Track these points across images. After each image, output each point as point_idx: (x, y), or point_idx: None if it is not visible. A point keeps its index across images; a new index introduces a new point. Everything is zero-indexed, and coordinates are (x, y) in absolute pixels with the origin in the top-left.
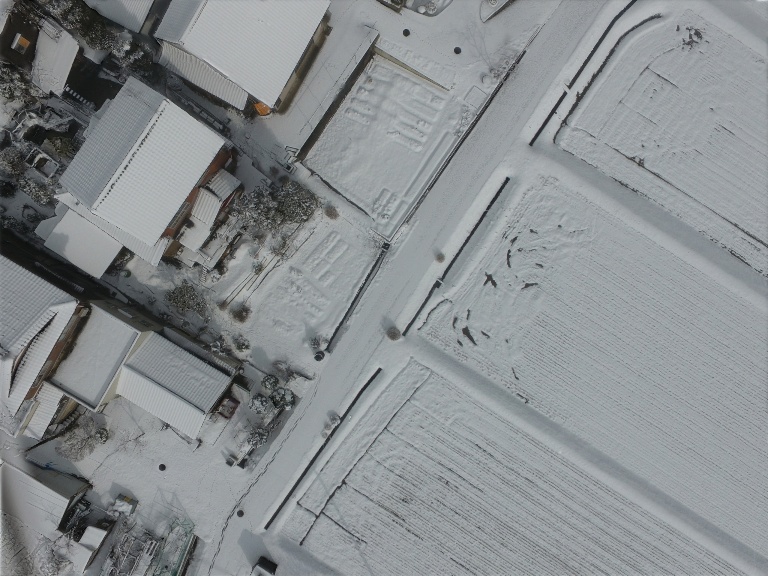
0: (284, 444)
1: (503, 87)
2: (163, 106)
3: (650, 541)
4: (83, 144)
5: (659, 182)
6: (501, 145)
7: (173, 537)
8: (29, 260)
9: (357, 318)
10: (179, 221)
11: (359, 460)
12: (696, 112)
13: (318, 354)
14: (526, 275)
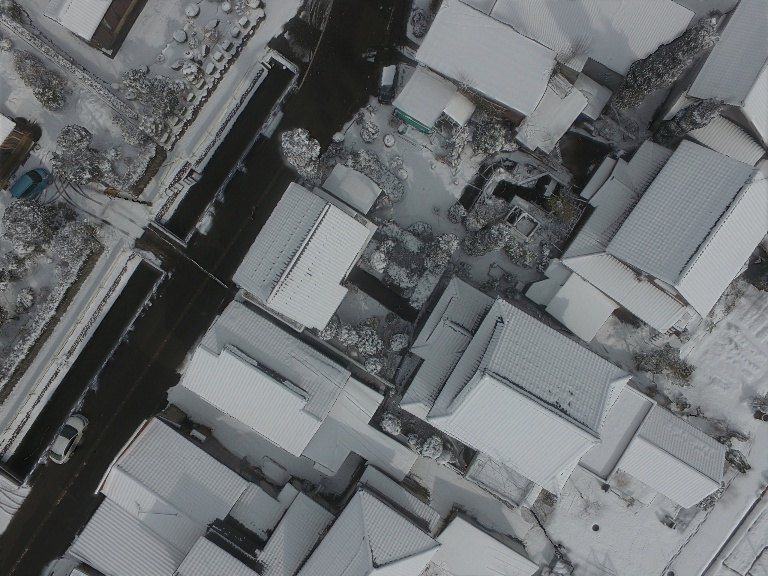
0: (716, 504)
1: None
2: (756, 176)
3: None
4: (634, 211)
5: None
6: None
7: None
8: None
9: None
10: None
11: None
12: None
13: (767, 414)
14: None
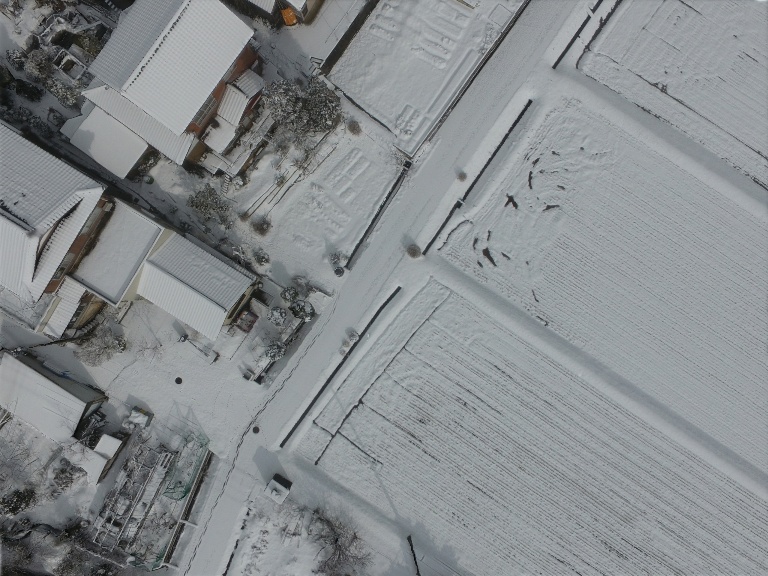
0: (301, 361)
1: (527, 9)
2: None
3: (670, 467)
4: (113, 33)
5: (682, 108)
6: (524, 66)
7: (188, 452)
8: None
9: (377, 235)
10: (205, 119)
11: (376, 379)
12: (720, 39)
13: (338, 268)
14: (547, 197)
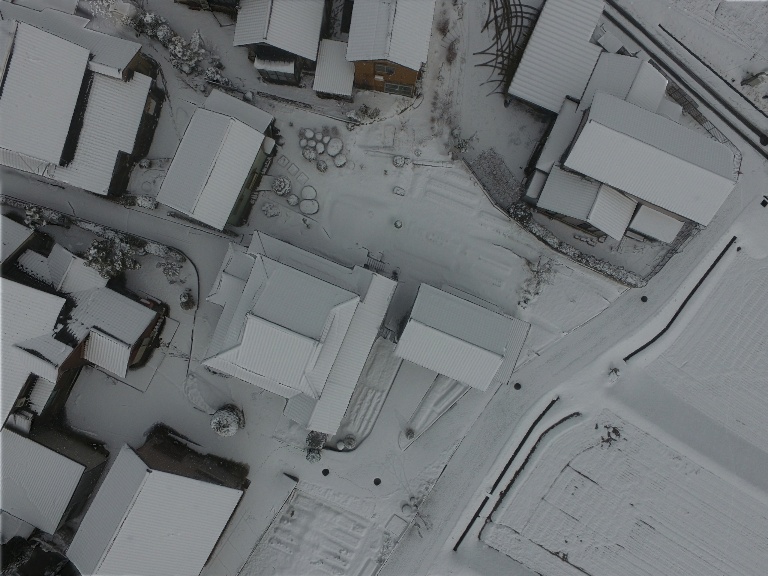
0: None
1: (425, 501)
2: None
3: None
4: None
5: None
6: (425, 559)
7: None
8: None
9: None
10: None
11: None
12: (617, 508)
13: None
14: None
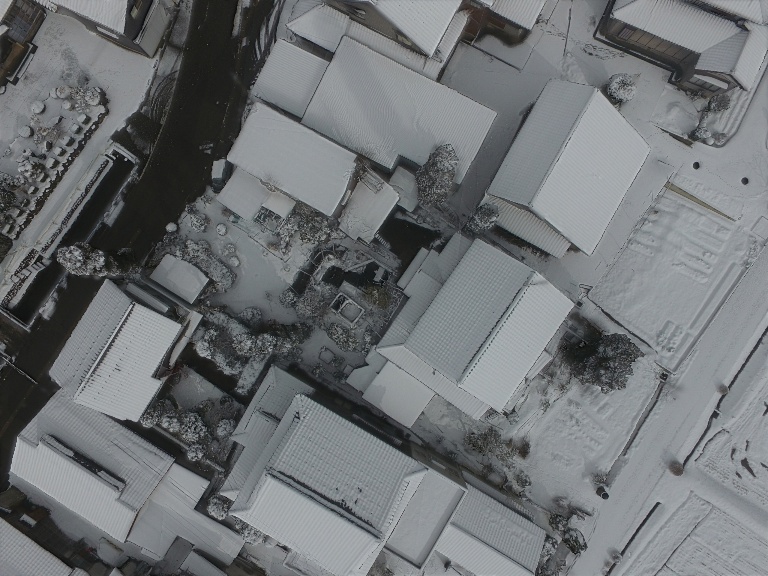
0: None
1: None
2: (532, 279)
3: None
4: (429, 308)
5: None
6: None
7: None
8: (338, 408)
9: (637, 451)
10: None
11: None
12: None
13: (605, 492)
14: None
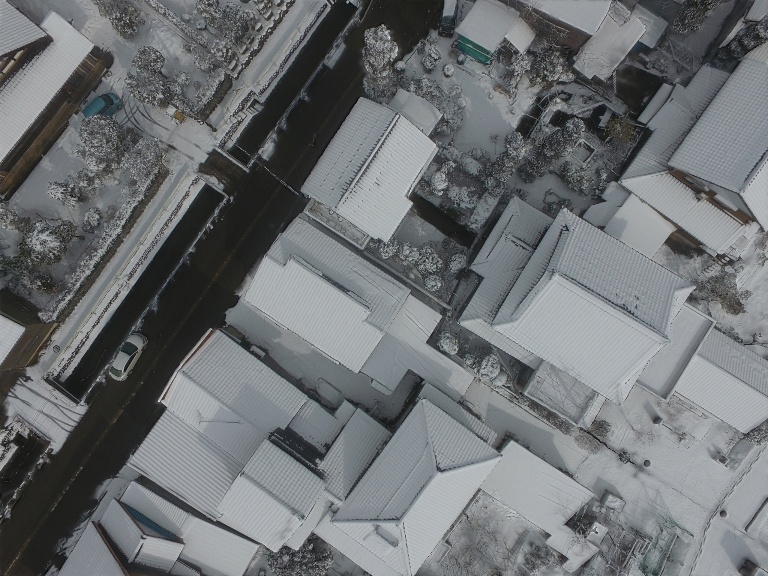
0: None
1: None
2: None
3: None
4: (696, 126)
5: None
6: None
7: None
8: None
9: None
10: None
11: None
12: None
13: None
14: None
